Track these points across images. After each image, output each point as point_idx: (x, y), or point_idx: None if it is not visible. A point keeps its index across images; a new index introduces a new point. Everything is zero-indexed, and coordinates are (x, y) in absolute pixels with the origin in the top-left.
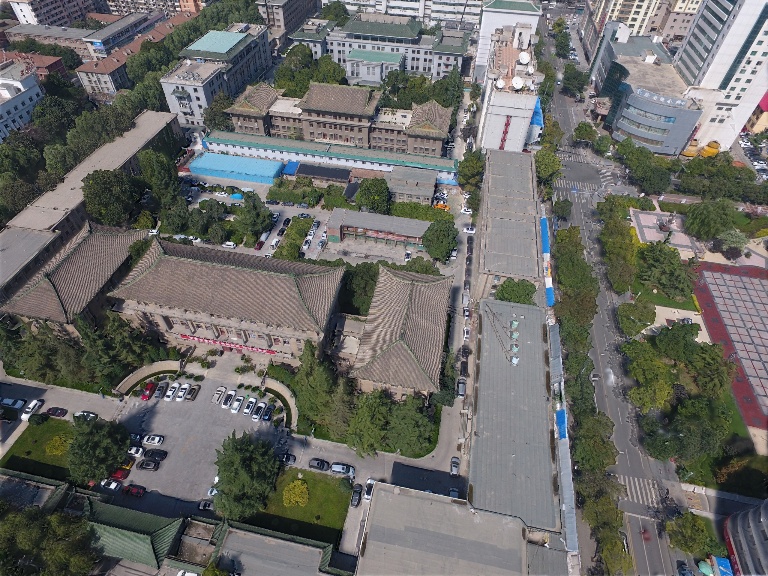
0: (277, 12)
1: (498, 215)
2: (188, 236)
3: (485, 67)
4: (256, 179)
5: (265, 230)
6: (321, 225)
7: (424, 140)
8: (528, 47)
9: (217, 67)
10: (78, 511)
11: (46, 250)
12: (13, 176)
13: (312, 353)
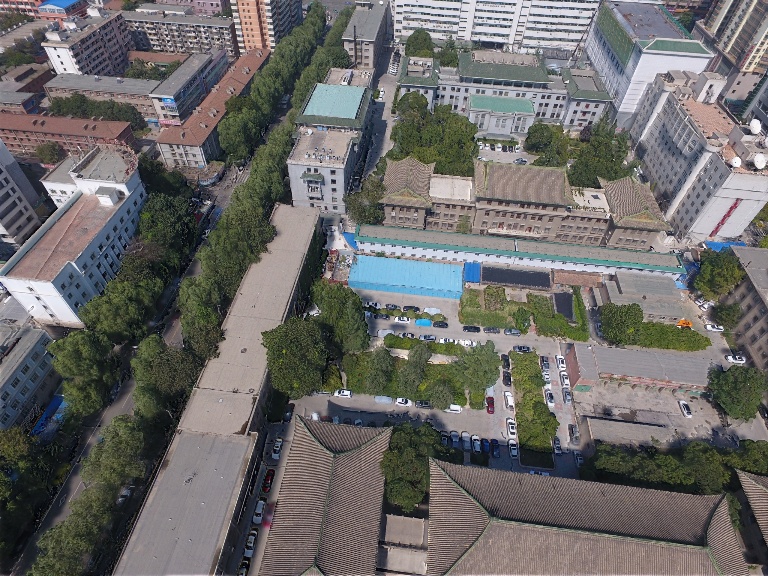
0: (366, 48)
1: None
2: (392, 396)
3: (629, 114)
4: (438, 293)
5: None
6: (549, 362)
7: (635, 231)
8: (715, 100)
9: (346, 136)
10: None
11: None
12: (159, 339)
13: None
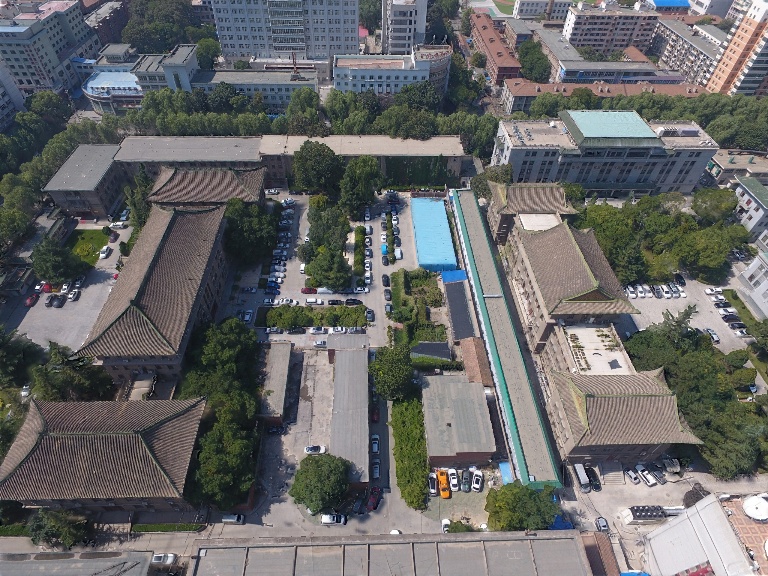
0: None
1: (353, 568)
2: None
3: None
4: None
5: (328, 286)
6: None
7: None
8: None
9: (564, 145)
10: (12, 275)
11: (245, 164)
12: (314, 114)
13: (57, 356)
